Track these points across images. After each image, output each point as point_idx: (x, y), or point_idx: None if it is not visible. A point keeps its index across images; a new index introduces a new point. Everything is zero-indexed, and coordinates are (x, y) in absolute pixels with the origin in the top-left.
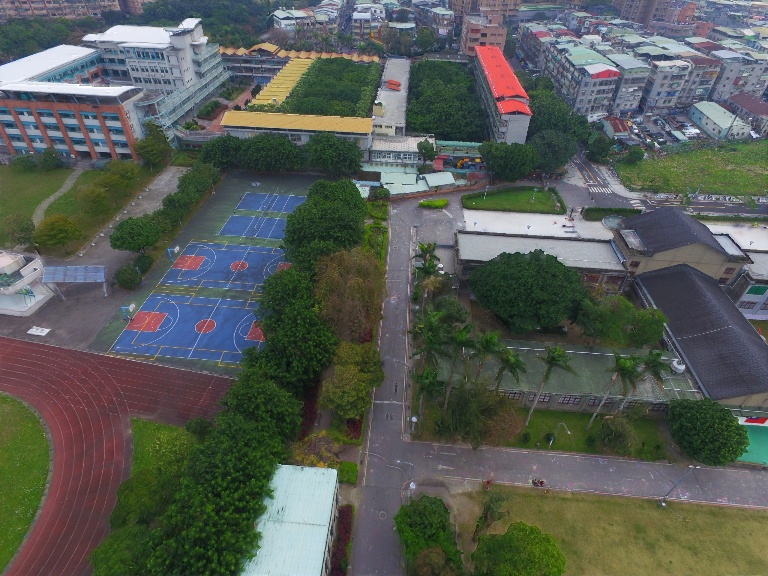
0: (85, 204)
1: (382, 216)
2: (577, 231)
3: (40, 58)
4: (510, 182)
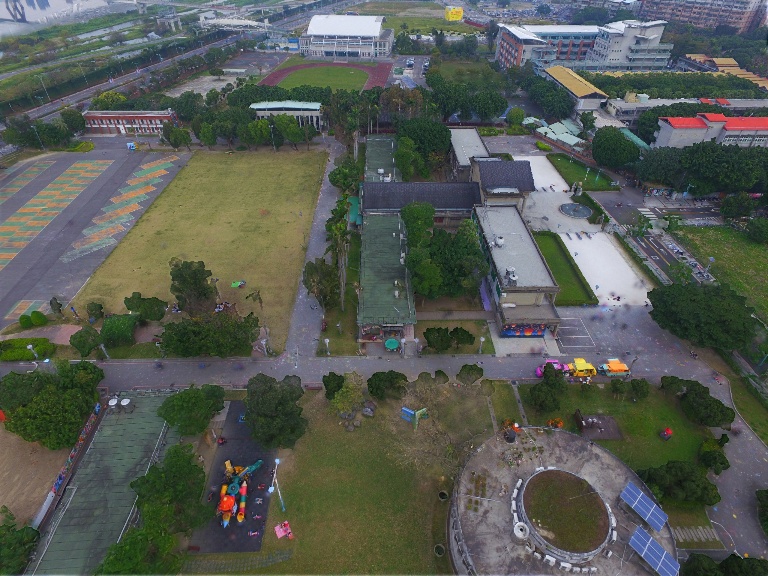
0: (455, 73)
1: (509, 131)
2: (548, 192)
3: (567, 27)
4: (615, 174)
